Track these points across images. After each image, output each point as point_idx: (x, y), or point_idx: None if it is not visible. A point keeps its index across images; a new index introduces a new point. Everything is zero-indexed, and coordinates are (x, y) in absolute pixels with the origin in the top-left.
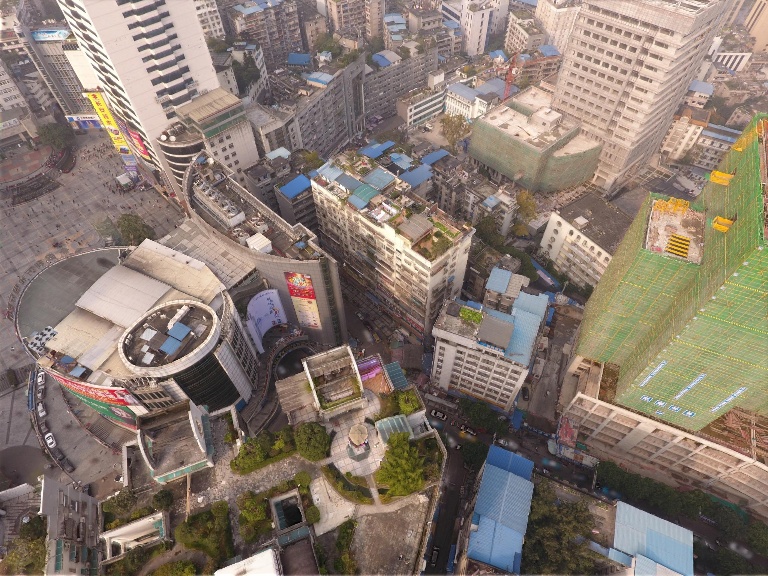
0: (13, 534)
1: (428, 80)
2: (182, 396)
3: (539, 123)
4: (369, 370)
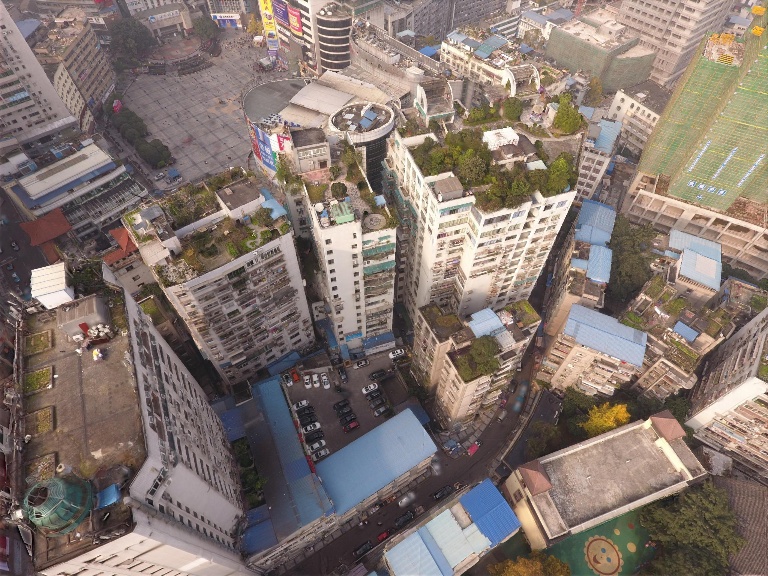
0: (332, 158)
1: (507, 5)
2: (364, 167)
3: (606, 32)
4: None
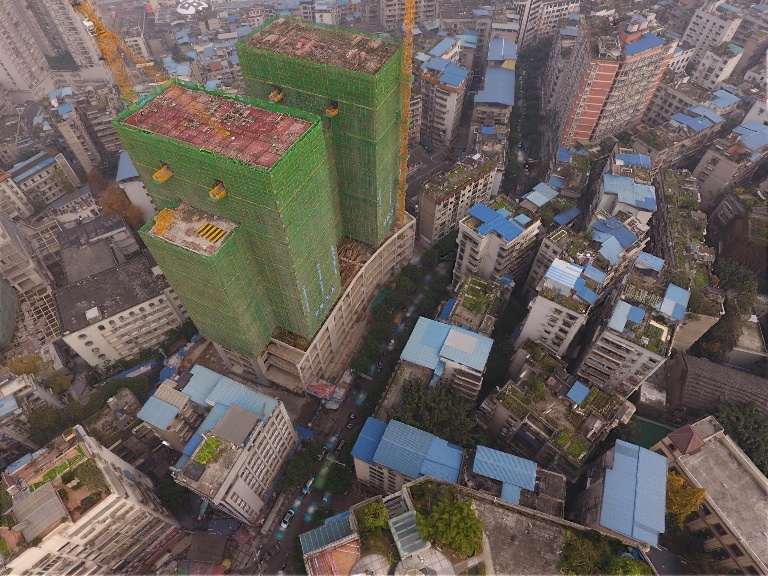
0: None
1: None
2: None
3: None
4: (328, 569)
